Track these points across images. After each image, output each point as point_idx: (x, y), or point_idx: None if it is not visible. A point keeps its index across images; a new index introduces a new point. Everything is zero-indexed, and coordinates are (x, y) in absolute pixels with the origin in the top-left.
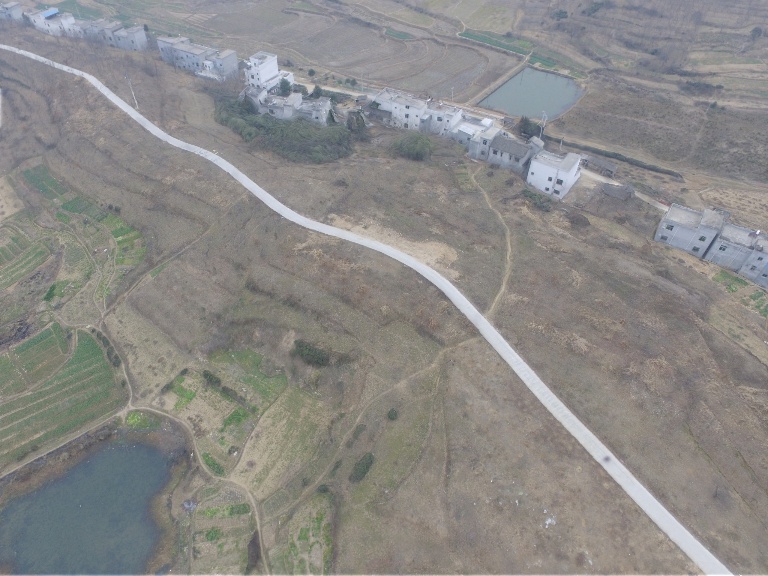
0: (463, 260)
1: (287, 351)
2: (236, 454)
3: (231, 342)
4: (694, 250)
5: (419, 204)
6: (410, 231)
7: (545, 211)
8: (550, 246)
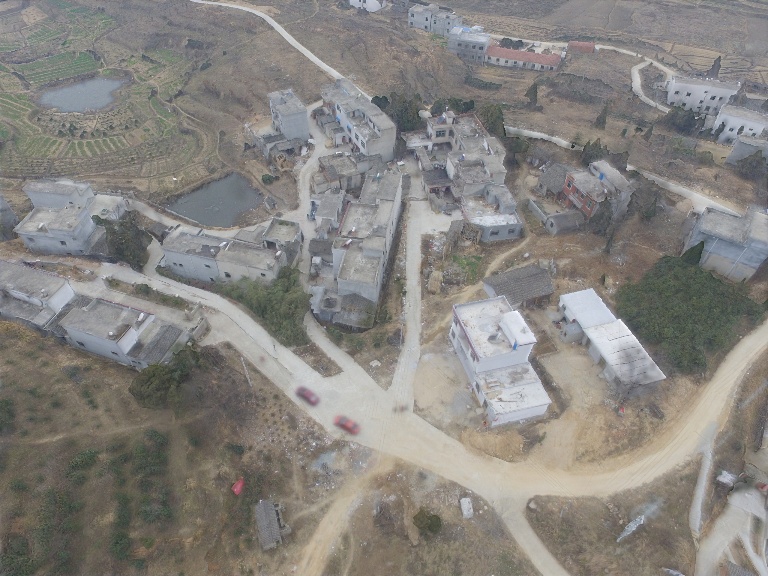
0: (282, 13)
1: (184, 46)
2: (153, 76)
3: (157, 44)
4: (426, 28)
5: (274, 2)
6: (260, 5)
7: (347, 9)
8: (337, 17)
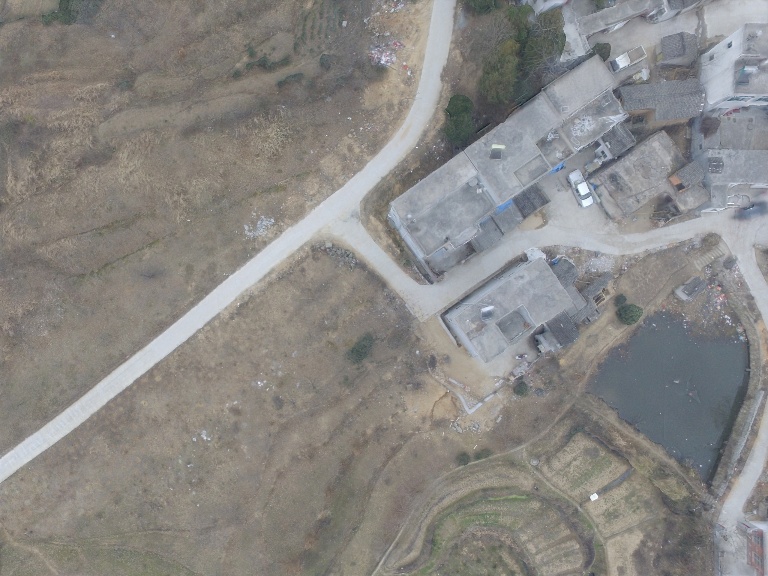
0: None
1: None
2: None
3: None
4: None
5: None
6: None
7: None
8: None
